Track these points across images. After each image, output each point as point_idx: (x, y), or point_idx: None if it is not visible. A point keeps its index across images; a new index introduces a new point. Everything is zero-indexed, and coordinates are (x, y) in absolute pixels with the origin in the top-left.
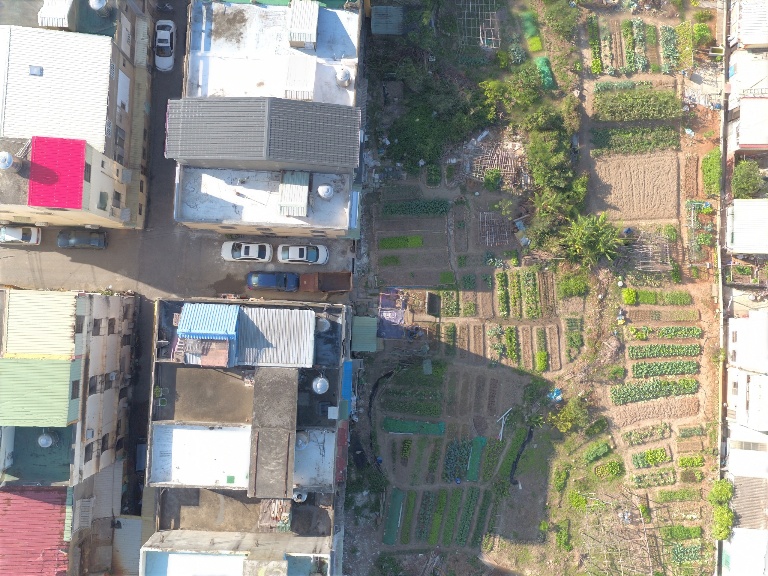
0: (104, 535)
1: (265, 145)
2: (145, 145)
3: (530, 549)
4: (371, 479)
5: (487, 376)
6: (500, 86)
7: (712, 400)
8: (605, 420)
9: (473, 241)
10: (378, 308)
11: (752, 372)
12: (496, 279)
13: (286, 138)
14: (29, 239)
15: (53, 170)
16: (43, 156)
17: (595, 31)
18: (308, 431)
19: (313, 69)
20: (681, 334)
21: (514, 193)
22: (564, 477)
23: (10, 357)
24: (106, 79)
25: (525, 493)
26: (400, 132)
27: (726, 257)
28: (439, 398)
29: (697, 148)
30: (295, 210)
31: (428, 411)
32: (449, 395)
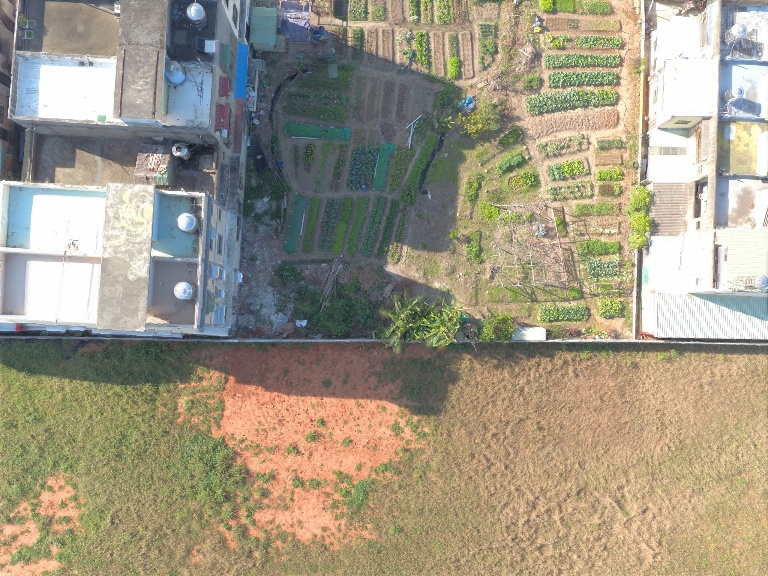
0: None
1: None
2: None
3: (439, 261)
4: (272, 184)
5: (396, 82)
6: None
7: (632, 113)
8: (520, 130)
9: None
10: (279, 2)
11: None
12: None
13: None
14: None
15: None
16: None
17: None
18: (183, 64)
19: None
20: (600, 44)
21: None
22: (476, 187)
23: None
24: None
25: (435, 203)
26: None
27: None
28: (344, 102)
29: None
30: None
31: (333, 115)
32: (355, 99)
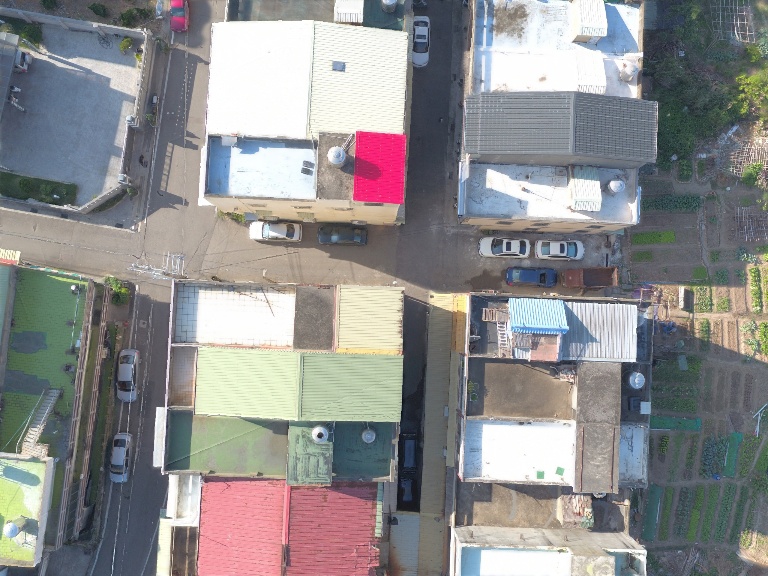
0: None
1: (571, 139)
2: None
3: None
4: None
5: (742, 372)
6: (761, 80)
7: None
8: None
9: (725, 236)
10: None
11: None
12: (749, 274)
13: (590, 132)
14: (292, 235)
15: (376, 165)
16: (367, 151)
17: None
18: (621, 426)
19: (601, 64)
20: None
21: (765, 188)
22: None
23: (342, 352)
24: (403, 74)
25: None
26: None
27: None
28: (696, 394)
29: None
30: (590, 205)
31: (685, 407)
32: (705, 391)
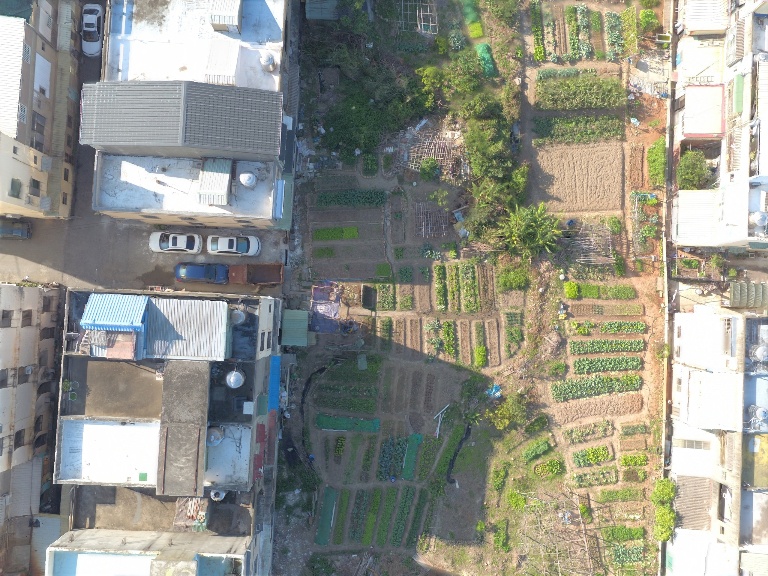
0: (22, 534)
1: (180, 130)
2: (70, 132)
3: (467, 550)
4: (303, 477)
5: (424, 372)
6: (436, 73)
7: (656, 397)
8: (545, 417)
9: (410, 233)
10: (310, 301)
11: (694, 368)
12: (434, 272)
13: (203, 123)
14: None
15: None
16: None
17: (538, 17)
18: (222, 427)
19: (236, 53)
20: (625, 329)
21: (453, 183)
22: (502, 476)
23: None
24: (19, 62)
25: (462, 492)
26: (335, 120)
27: (672, 250)
28: (374, 394)
29: (643, 138)
30: (215, 198)
31: (362, 407)
32: (384, 391)
